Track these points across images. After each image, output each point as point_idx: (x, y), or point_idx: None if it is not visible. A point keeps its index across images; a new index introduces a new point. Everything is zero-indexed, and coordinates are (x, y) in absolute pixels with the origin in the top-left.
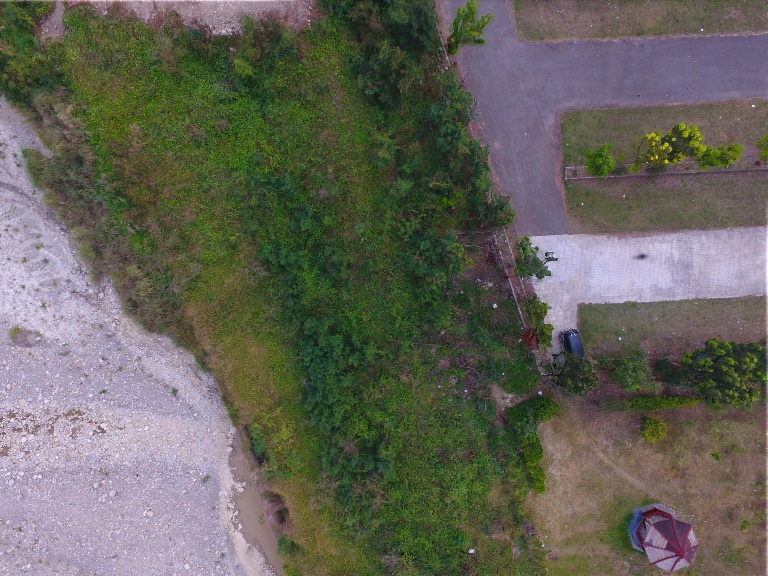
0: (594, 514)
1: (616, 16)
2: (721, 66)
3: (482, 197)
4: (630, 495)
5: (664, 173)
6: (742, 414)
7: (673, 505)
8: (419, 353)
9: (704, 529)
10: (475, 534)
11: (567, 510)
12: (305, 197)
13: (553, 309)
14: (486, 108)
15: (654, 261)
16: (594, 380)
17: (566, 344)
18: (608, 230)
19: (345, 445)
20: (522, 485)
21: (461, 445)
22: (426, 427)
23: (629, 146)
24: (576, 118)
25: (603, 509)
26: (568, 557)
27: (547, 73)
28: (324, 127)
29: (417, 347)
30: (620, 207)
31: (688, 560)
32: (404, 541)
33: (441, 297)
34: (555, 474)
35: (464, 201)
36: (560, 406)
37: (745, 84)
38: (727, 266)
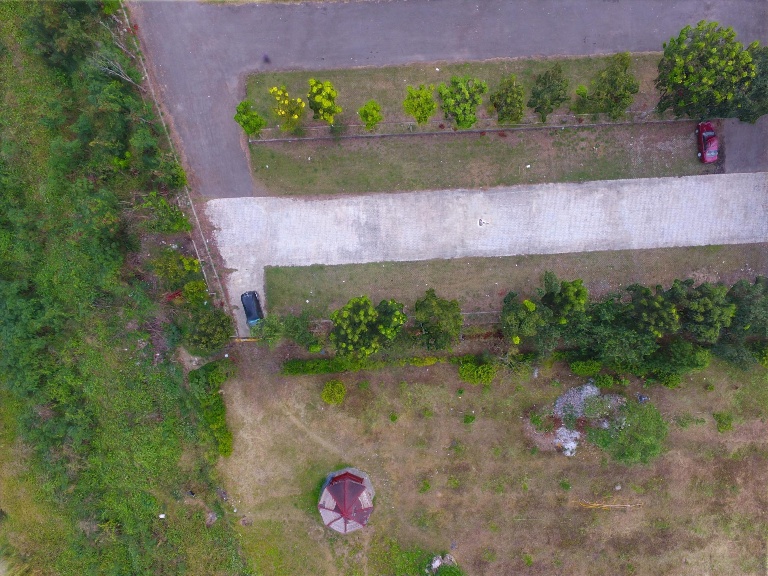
0: (288, 479)
1: None
2: (404, 30)
3: None
4: (323, 459)
5: (349, 136)
6: (433, 377)
7: (367, 469)
8: (104, 315)
9: (398, 493)
10: (164, 499)
11: (260, 474)
12: (1, 161)
13: (239, 271)
14: (168, 70)
15: (341, 224)
16: (215, 334)
17: (243, 305)
18: (294, 193)
19: (39, 409)
20: (210, 449)
21: (148, 408)
22: (112, 390)
23: None
24: (260, 81)
25: (297, 473)
26: (263, 522)
27: (229, 36)
28: (6, 89)
29: (99, 309)
30: (306, 170)
31: (360, 522)
32: (109, 508)
33: (115, 258)
34: (246, 438)
35: (141, 162)
36: (250, 369)
37: (429, 48)
38: (414, 229)
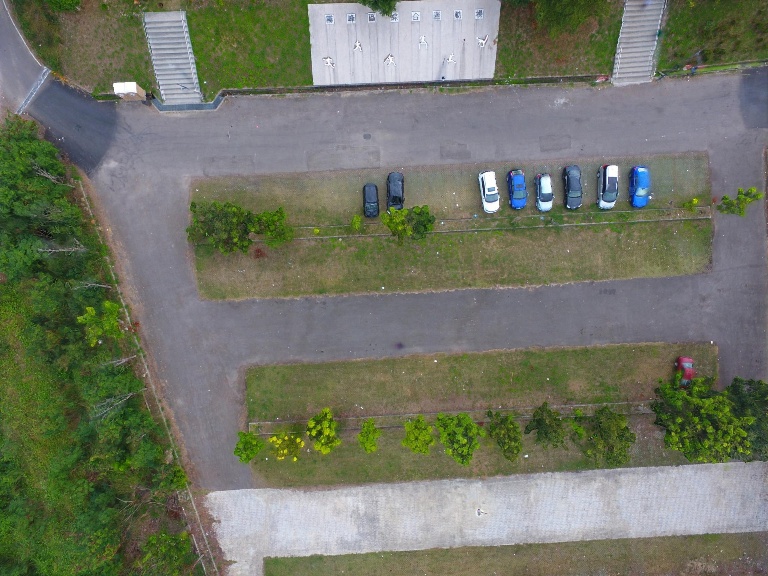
0: None
1: (298, 275)
2: (403, 323)
3: (161, 457)
4: None
5: (348, 428)
6: None
7: None
8: None
9: None
10: None
11: None
12: (2, 443)
13: (238, 563)
14: (169, 366)
15: (340, 514)
16: None
17: None
18: (293, 484)
19: None
20: None
21: None
22: None
23: (313, 401)
24: (260, 374)
25: None
26: None
27: (230, 331)
28: (8, 384)
29: None
30: (305, 461)
31: None
32: None
33: (115, 561)
34: None
35: None
36: None
37: (427, 340)
38: (413, 519)
